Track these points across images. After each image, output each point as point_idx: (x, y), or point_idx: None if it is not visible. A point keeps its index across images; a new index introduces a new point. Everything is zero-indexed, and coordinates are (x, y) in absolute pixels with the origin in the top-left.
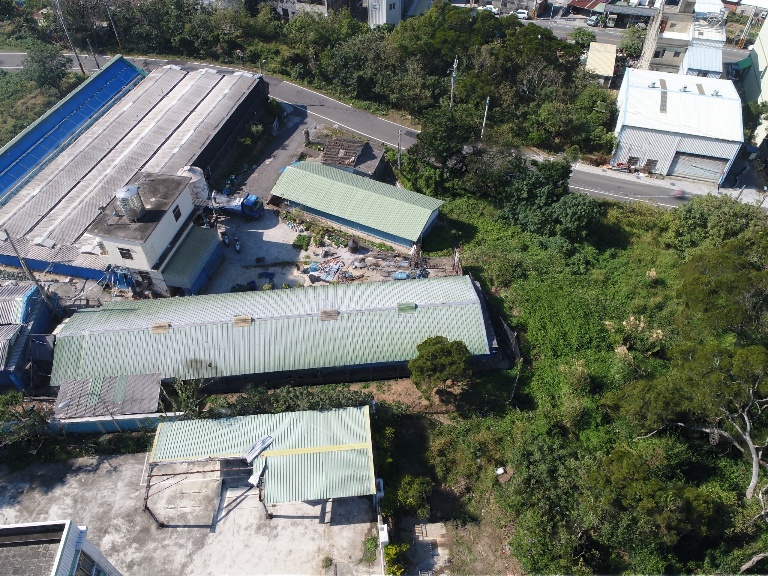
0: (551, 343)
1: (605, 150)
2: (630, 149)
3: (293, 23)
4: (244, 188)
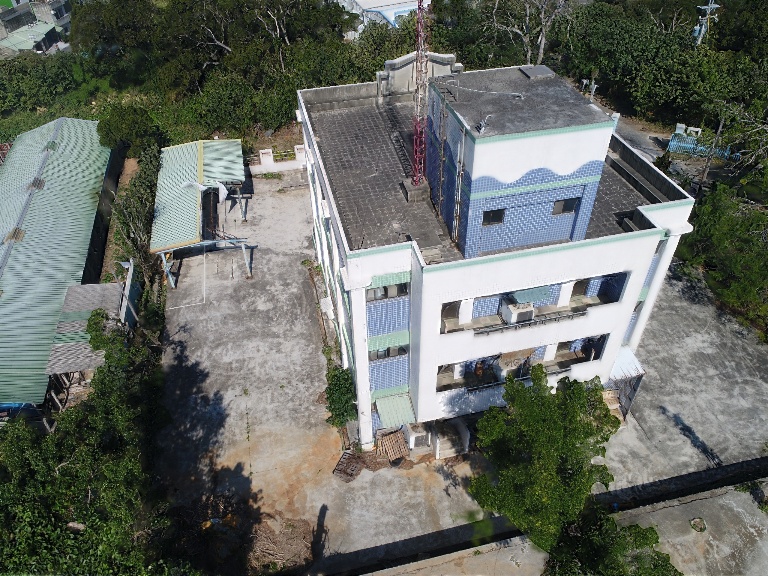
0: None
1: None
2: None
3: None
4: None
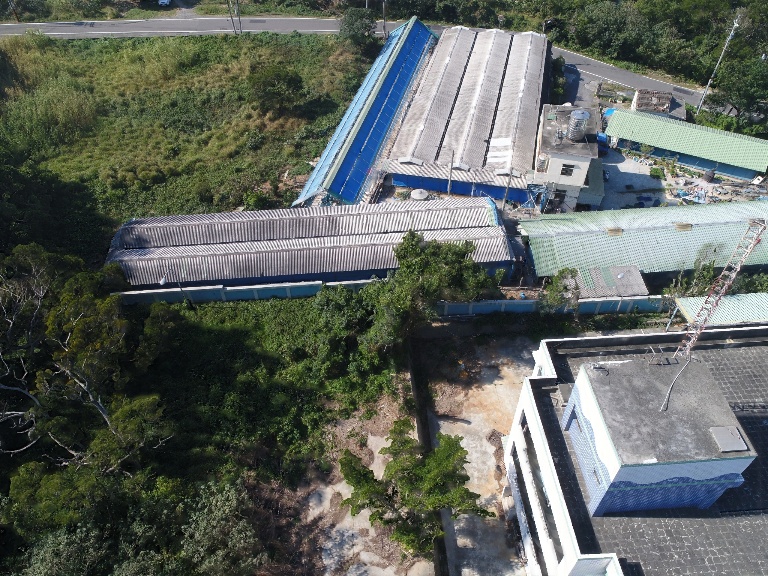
0: None
1: None
2: None
3: None
4: None
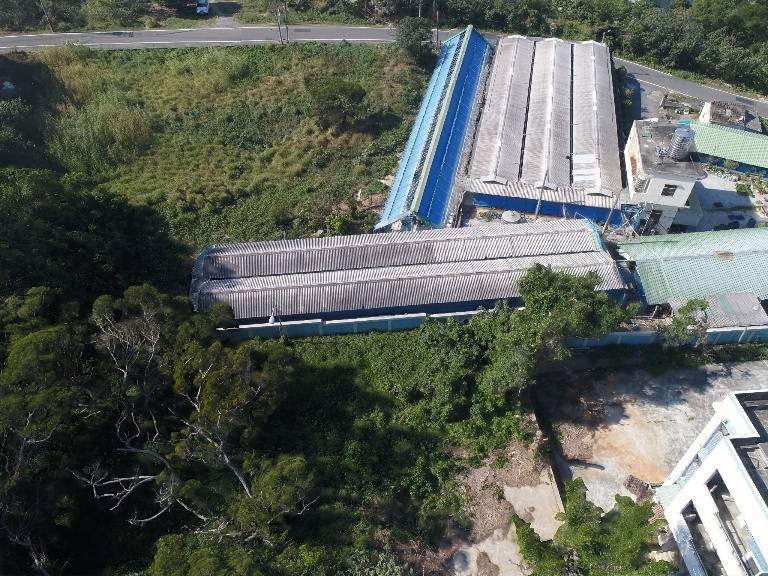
0: None
1: None
2: None
3: (562, 1)
4: None
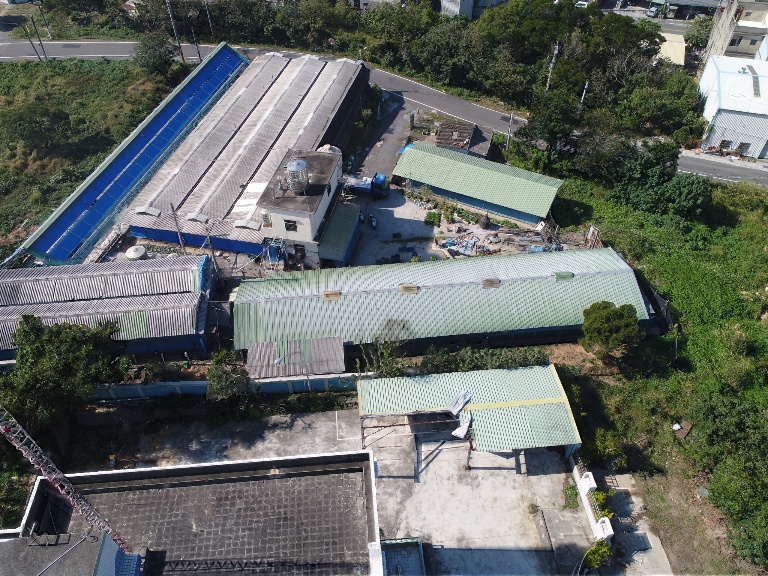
0: (697, 311)
1: (696, 134)
2: (724, 133)
3: (371, 14)
4: (363, 169)
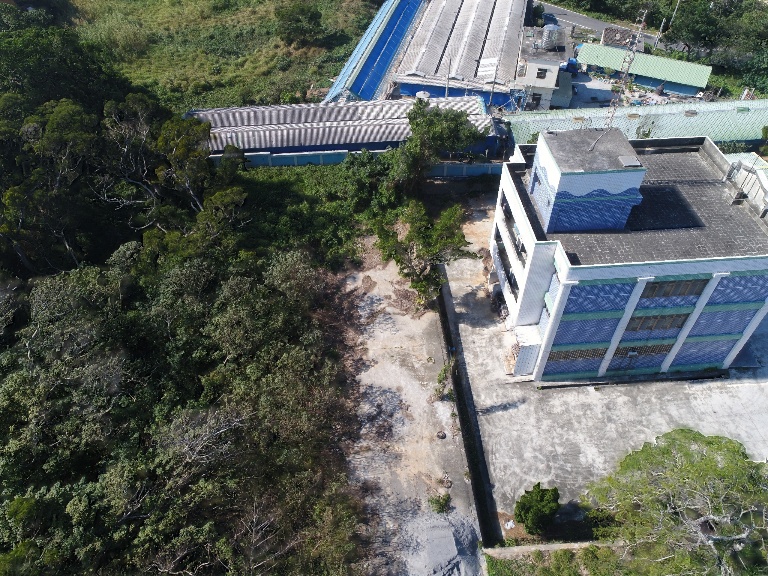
0: None
1: None
2: None
3: None
4: None
